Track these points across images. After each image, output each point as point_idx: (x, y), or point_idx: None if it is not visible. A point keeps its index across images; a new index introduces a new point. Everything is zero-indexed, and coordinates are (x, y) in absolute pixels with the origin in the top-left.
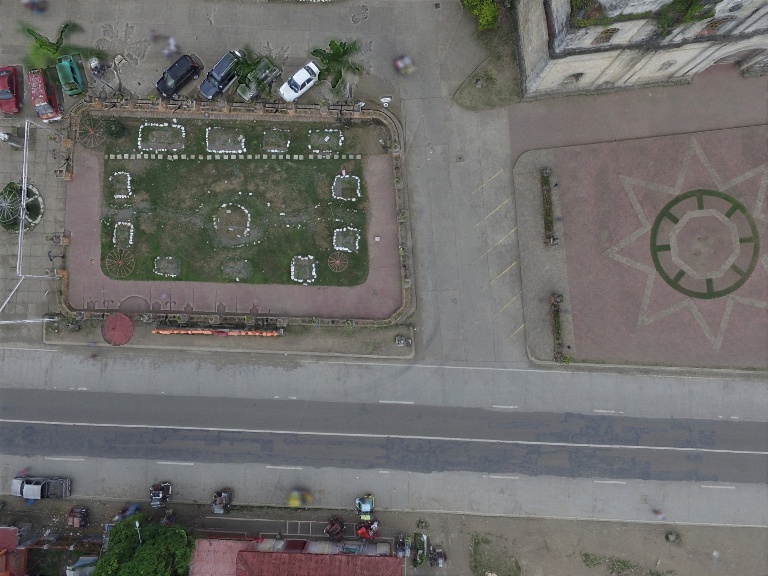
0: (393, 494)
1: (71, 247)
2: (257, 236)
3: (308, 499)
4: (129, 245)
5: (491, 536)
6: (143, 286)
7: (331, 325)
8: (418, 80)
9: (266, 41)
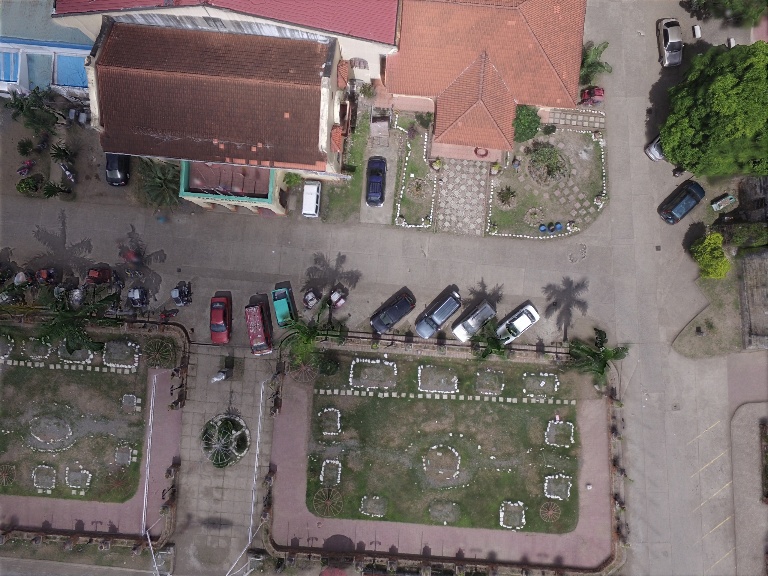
0: None
1: (277, 482)
2: (466, 479)
3: None
4: (336, 484)
5: None
6: (348, 525)
7: (541, 575)
8: (636, 324)
9: (480, 276)
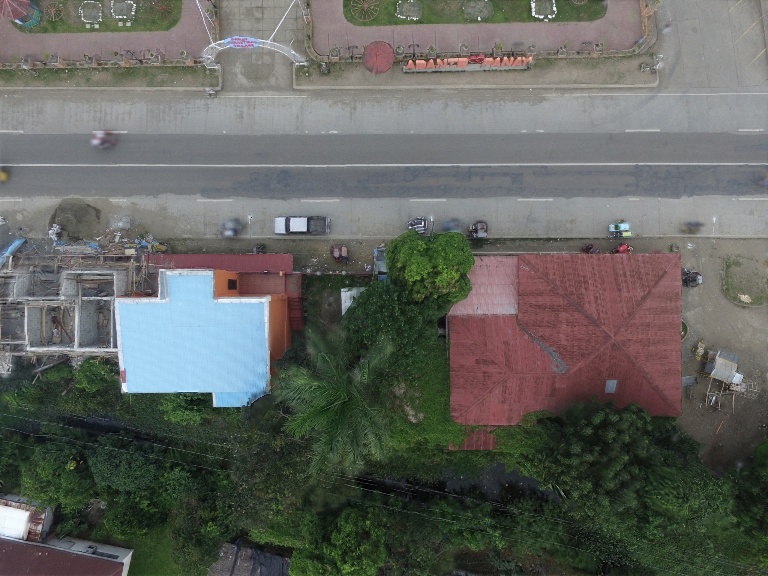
0: (644, 220)
1: None
2: None
3: (560, 229)
4: None
5: (742, 259)
6: (386, 31)
7: (576, 57)
8: None
9: None
